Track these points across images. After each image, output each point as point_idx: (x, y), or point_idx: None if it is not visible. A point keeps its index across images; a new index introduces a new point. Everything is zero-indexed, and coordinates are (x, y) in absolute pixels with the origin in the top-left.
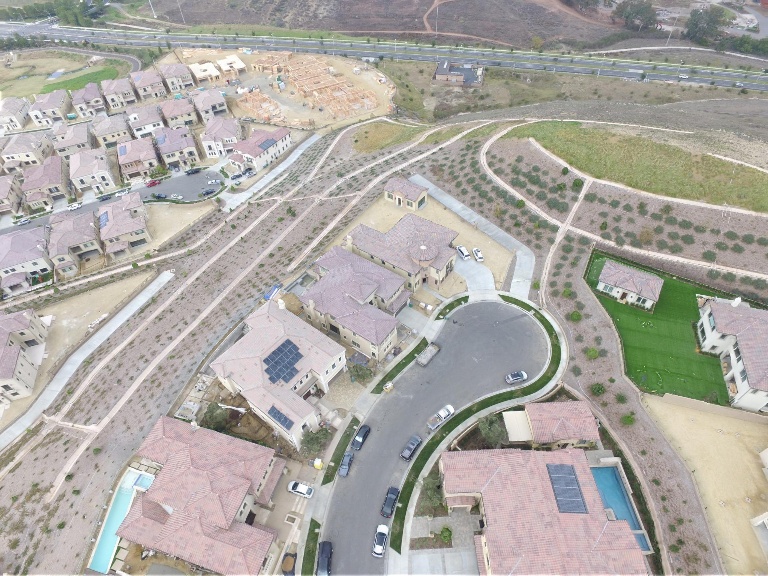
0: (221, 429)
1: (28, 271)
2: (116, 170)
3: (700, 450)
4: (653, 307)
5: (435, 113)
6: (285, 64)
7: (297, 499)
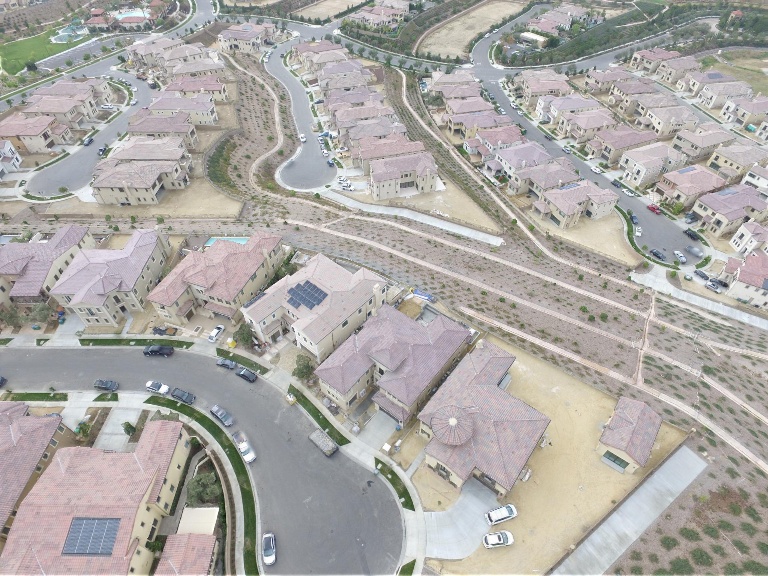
0: (276, 277)
1: (505, 169)
2: None
3: None
4: None
5: None
6: None
7: None
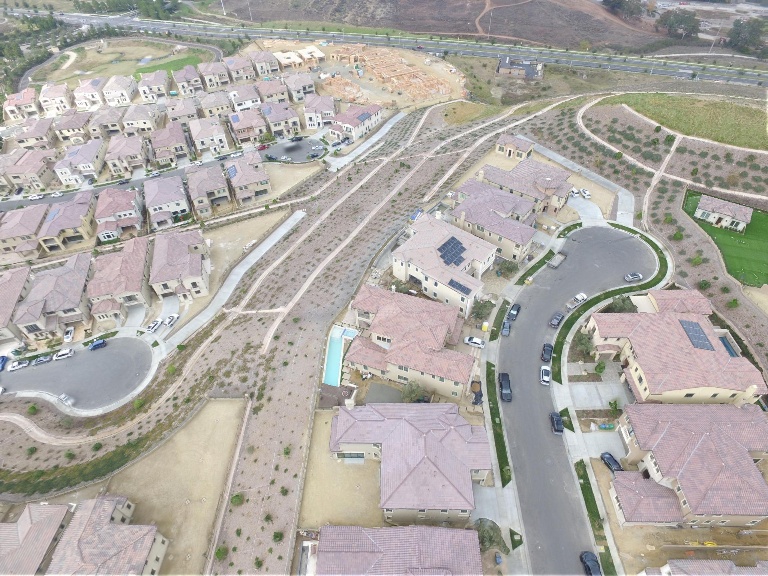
0: None
1: (171, 211)
2: (227, 136)
3: None
4: (744, 230)
5: (503, 100)
6: (361, 54)
7: (473, 349)
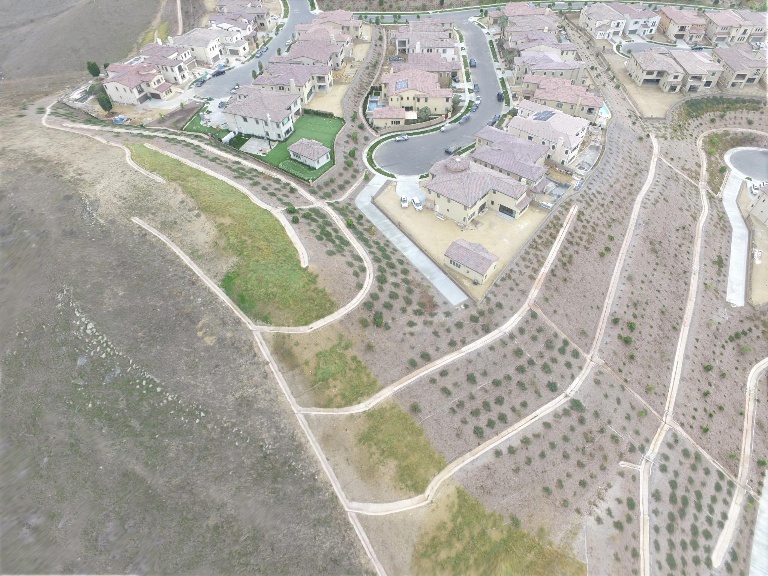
0: None
1: None
2: None
3: (331, 106)
4: None
5: None
6: None
7: None
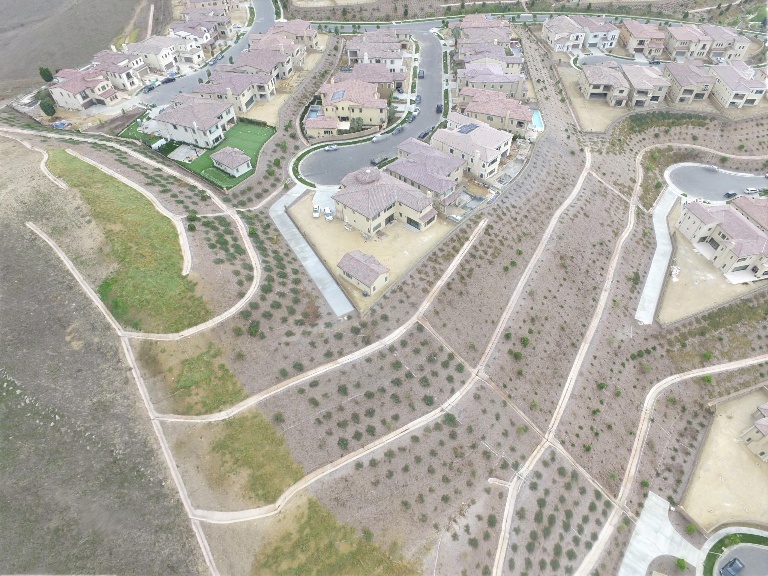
0: None
1: None
2: None
3: (268, 115)
4: None
5: None
6: None
7: None
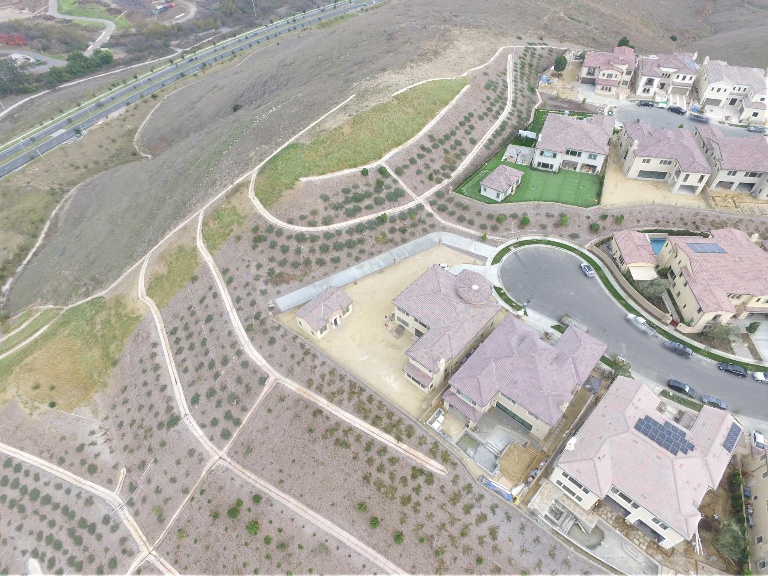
0: None
1: None
2: None
3: (633, 196)
4: None
5: None
6: None
7: None
